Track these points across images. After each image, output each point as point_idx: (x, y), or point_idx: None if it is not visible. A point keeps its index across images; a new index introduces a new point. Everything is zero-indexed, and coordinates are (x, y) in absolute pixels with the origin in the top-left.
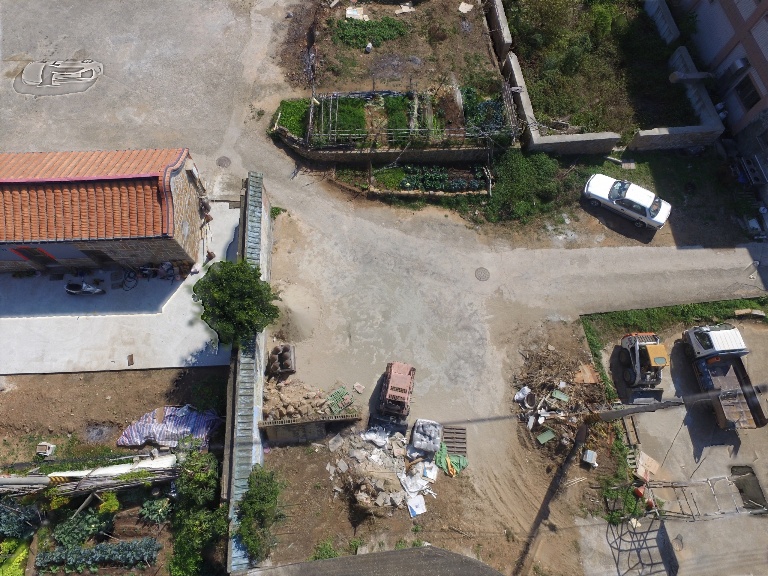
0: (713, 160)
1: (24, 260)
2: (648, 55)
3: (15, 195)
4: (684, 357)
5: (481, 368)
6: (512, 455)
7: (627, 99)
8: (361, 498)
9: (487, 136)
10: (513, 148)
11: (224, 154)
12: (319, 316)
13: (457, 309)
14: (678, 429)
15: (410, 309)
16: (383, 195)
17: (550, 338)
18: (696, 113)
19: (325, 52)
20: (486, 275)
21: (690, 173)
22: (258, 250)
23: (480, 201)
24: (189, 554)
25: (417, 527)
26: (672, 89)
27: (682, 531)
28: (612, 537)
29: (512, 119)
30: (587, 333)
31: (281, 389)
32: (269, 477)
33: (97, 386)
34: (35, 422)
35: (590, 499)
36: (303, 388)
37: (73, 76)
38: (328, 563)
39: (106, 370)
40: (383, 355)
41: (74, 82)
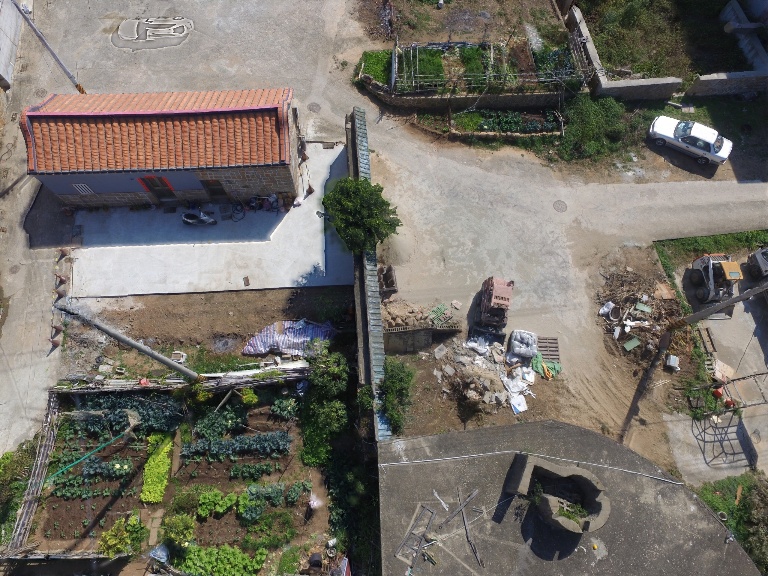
0: (766, 104)
1: (145, 192)
2: (700, 10)
3: (146, 126)
4: (750, 278)
5: (566, 287)
6: (601, 361)
7: (683, 50)
8: (471, 395)
9: (559, 80)
10: (582, 92)
11: (314, 100)
12: (414, 243)
13: (540, 236)
14: (749, 340)
15: (497, 237)
16: (463, 137)
17: (627, 261)
18: (749, 61)
19: (400, 8)
20: (564, 207)
21: (745, 116)
22: (369, 175)
23: (553, 141)
24: (319, 444)
25: (521, 422)
26: (725, 40)
27: (759, 426)
28: (697, 431)
29: (582, 65)
30: (660, 257)
31: (387, 305)
32: (400, 366)
33: (218, 304)
34: (166, 334)
35: (675, 398)
36: (406, 305)
37: (166, 32)
38: (463, 434)
39: (225, 290)
40: (476, 276)
41: (168, 37)
